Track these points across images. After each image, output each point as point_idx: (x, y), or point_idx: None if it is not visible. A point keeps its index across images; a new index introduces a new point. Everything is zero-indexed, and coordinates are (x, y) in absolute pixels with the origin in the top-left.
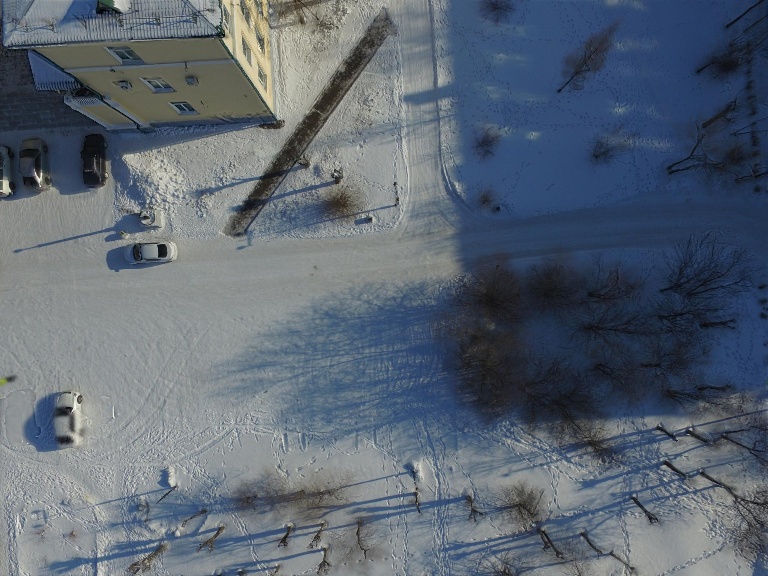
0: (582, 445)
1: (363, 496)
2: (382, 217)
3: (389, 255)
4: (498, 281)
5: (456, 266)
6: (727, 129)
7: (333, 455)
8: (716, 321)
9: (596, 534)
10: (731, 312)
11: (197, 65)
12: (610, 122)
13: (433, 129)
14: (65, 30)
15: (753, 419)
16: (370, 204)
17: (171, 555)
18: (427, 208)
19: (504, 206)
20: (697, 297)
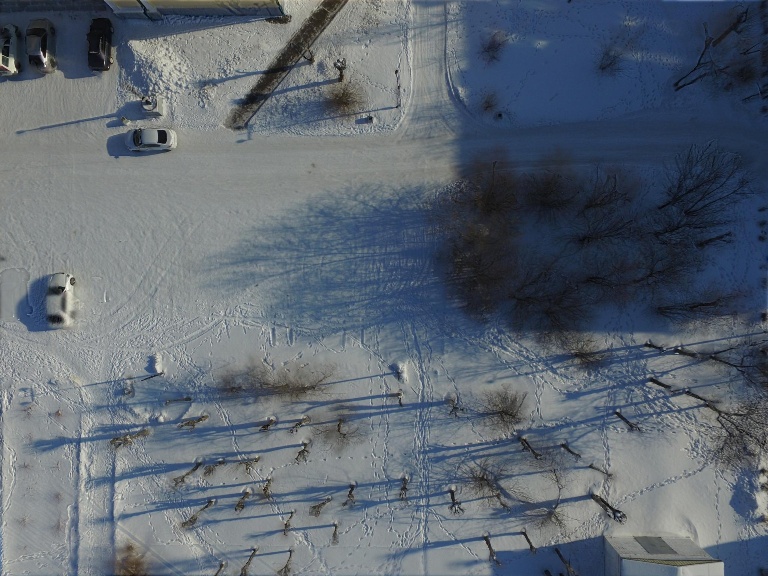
0: (569, 356)
1: (347, 394)
2: (383, 118)
3: (388, 157)
4: (495, 187)
5: (454, 172)
6: (737, 48)
7: (319, 352)
8: (712, 237)
9: (577, 446)
10: (728, 226)
11: None
12: (619, 35)
13: (440, 33)
14: None
15: (743, 342)
16: (372, 104)
17: (154, 440)
18: (429, 112)
19: (506, 114)
20: (695, 215)
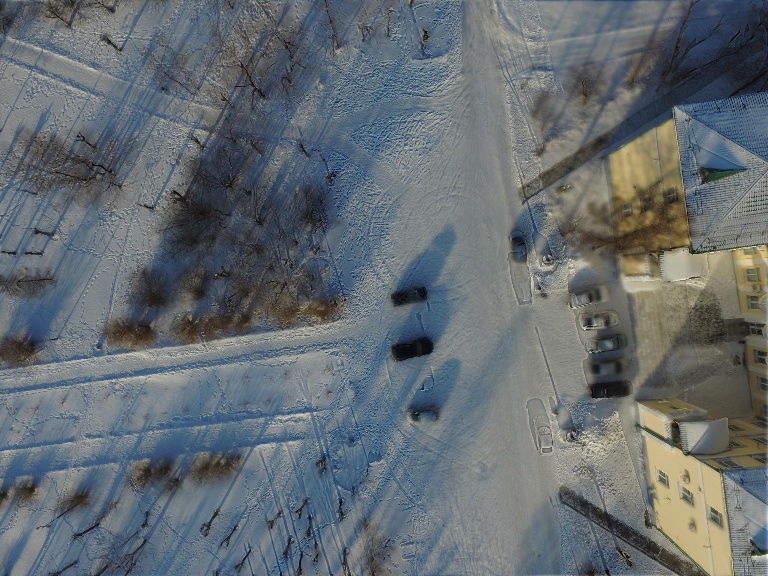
0: None
1: None
2: None
3: None
4: None
5: None
6: None
7: None
8: None
9: None
10: None
11: (708, 550)
12: None
13: None
14: (737, 516)
15: None
16: None
17: None
18: None
19: None
20: None
